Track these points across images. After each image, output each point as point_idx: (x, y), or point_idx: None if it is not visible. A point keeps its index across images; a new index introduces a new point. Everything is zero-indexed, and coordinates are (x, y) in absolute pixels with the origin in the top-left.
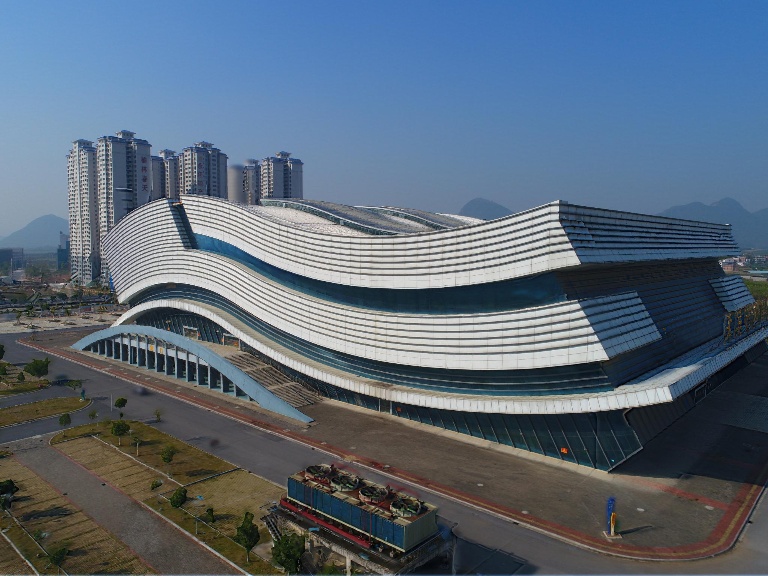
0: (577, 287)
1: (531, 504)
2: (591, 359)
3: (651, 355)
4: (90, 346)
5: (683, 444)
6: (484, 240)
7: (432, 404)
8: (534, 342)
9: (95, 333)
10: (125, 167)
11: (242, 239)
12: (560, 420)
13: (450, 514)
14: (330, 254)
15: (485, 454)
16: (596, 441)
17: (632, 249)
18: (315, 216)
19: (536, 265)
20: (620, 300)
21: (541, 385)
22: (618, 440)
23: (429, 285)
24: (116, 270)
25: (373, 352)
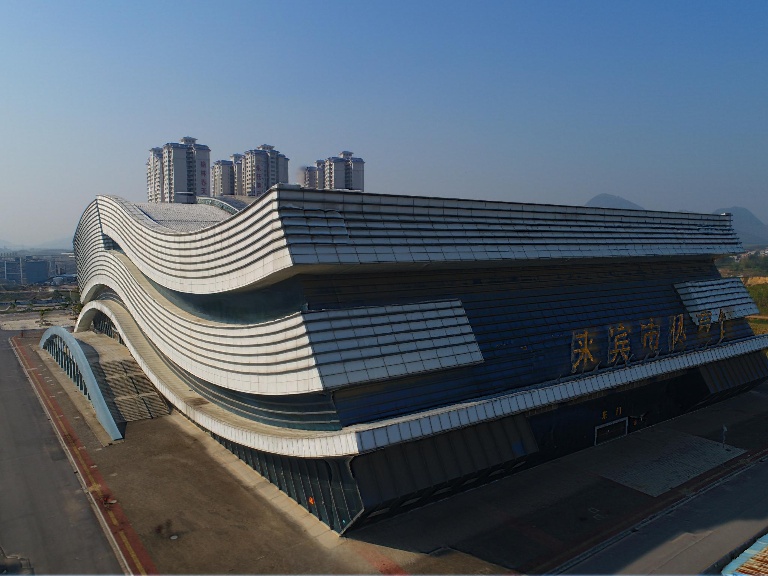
0: (345, 294)
1: (190, 572)
2: (311, 388)
3: (468, 383)
4: (46, 345)
5: (502, 502)
6: (236, 236)
7: (215, 429)
8: (276, 362)
9: (45, 333)
10: (186, 172)
11: (122, 239)
12: (307, 462)
13: (83, 575)
14: (160, 254)
15: (235, 495)
16: (330, 493)
17: (448, 246)
18: (225, 213)
19: (266, 266)
20: (410, 311)
21: (294, 416)
22: (345, 495)
23: (209, 290)
24: (78, 271)
25: (190, 364)
